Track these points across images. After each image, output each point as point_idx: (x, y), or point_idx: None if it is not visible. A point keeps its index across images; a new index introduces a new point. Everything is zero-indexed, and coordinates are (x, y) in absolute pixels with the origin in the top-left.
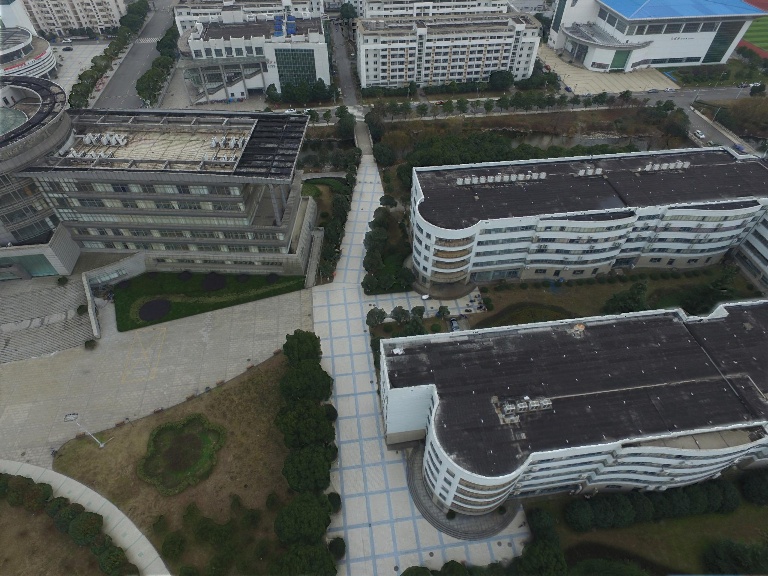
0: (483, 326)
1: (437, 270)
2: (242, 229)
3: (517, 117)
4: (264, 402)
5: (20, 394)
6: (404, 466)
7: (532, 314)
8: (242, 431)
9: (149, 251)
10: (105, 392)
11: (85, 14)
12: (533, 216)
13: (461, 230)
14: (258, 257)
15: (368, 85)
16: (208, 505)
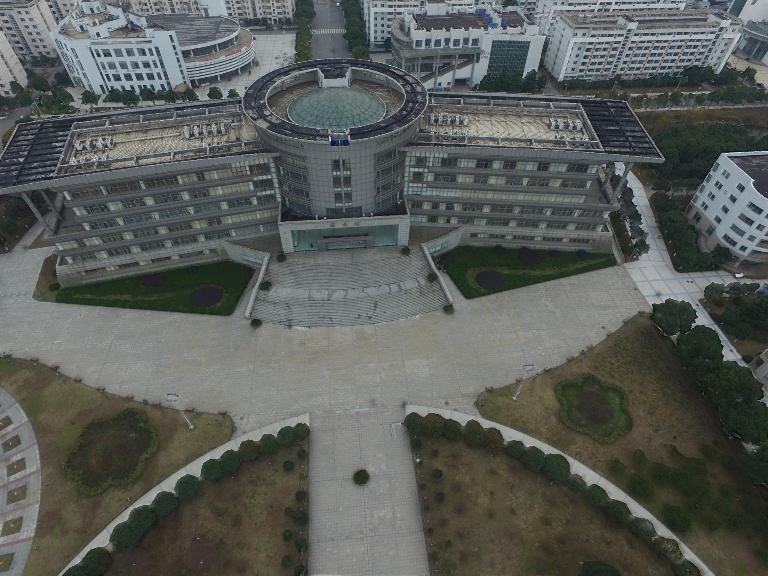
0: None
1: (760, 250)
2: (577, 206)
3: (724, 111)
4: (642, 365)
5: (410, 351)
6: None
7: None
8: (638, 390)
9: (470, 226)
10: (487, 352)
11: (261, 5)
12: None
13: None
14: (573, 234)
15: (565, 77)
16: (646, 453)
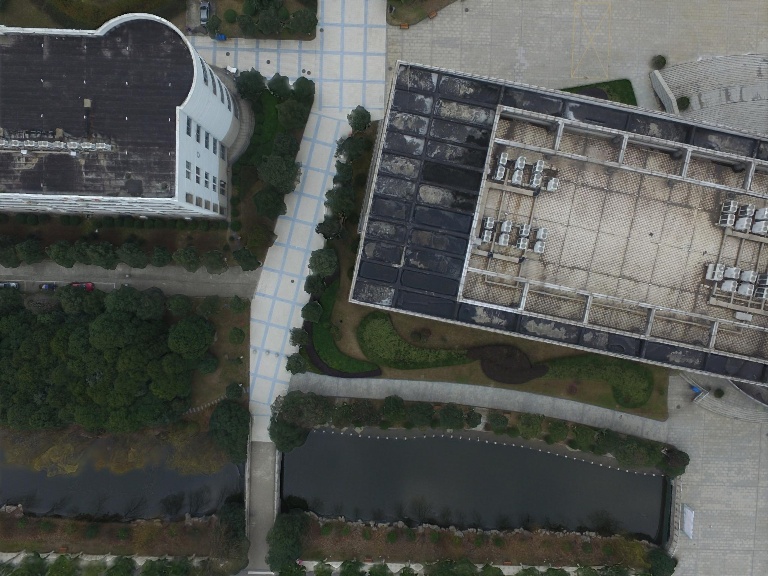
0: (169, 6)
1: None
2: None
3: None
4: None
5: (720, 6)
6: None
7: (98, 15)
8: None
9: None
10: None
11: None
12: (8, 28)
13: None
14: None
15: None
16: None
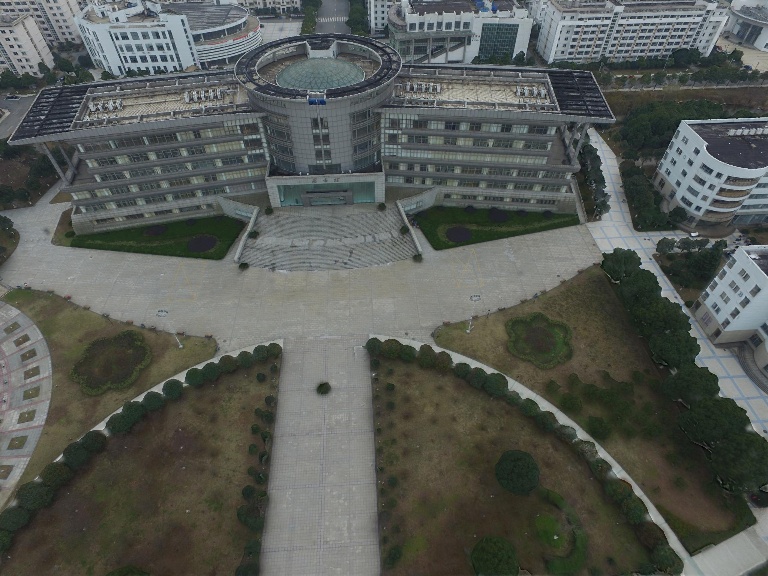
0: None
1: (713, 209)
2: (540, 167)
3: (708, 91)
4: (589, 307)
5: (379, 291)
6: (736, 360)
7: None
8: (582, 327)
9: (443, 187)
10: (449, 293)
11: None
12: None
13: (758, 169)
14: (539, 195)
15: (555, 60)
16: (581, 378)
